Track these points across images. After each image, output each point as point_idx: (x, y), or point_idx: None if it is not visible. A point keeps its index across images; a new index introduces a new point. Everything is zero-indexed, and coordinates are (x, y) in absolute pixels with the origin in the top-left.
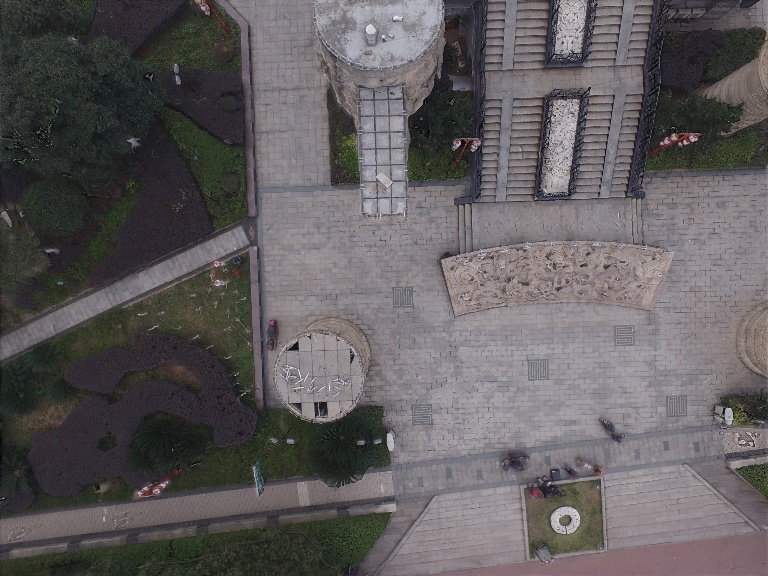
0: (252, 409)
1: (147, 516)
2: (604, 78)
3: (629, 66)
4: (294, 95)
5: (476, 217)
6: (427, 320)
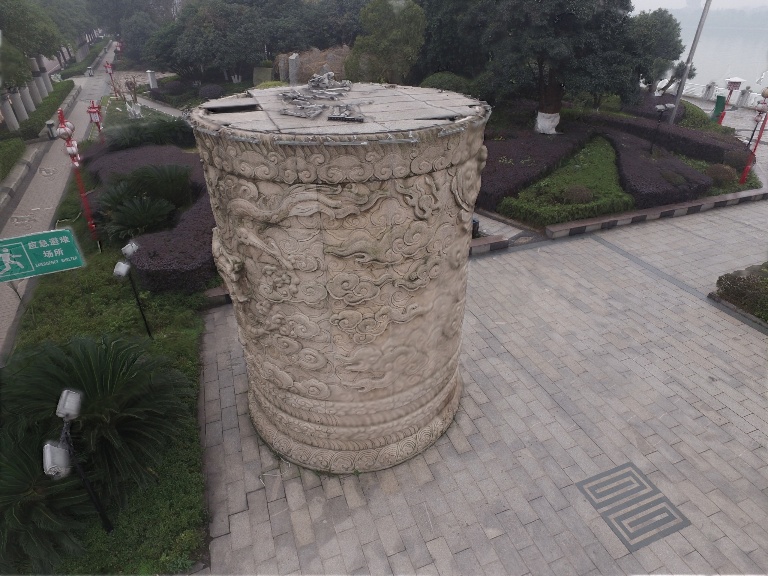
0: (208, 264)
1: (19, 234)
2: None
3: None
4: (766, 236)
5: None
6: None
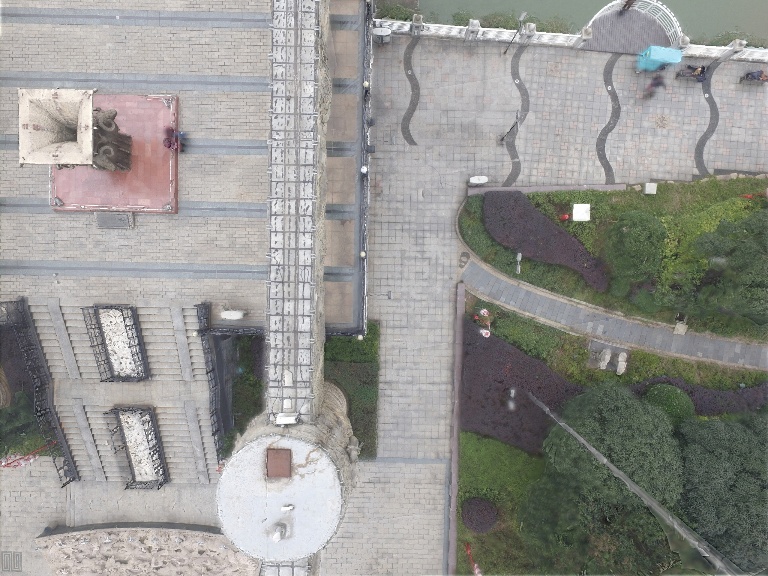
0: None
1: None
2: (175, 391)
3: None
4: None
5: (79, 493)
6: None
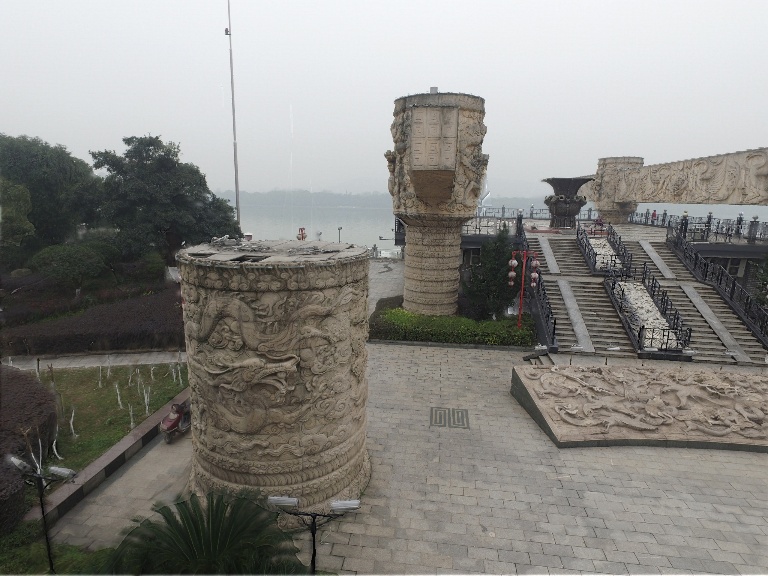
0: None
1: None
2: None
3: (681, 281)
4: None
5: (558, 360)
6: (499, 446)
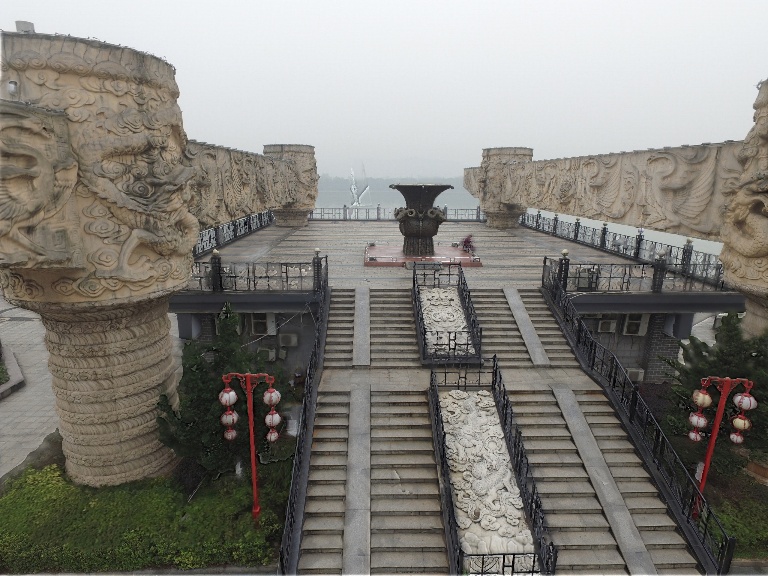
0: None
1: None
2: (524, 377)
3: (558, 368)
4: (9, 441)
5: None
6: None
